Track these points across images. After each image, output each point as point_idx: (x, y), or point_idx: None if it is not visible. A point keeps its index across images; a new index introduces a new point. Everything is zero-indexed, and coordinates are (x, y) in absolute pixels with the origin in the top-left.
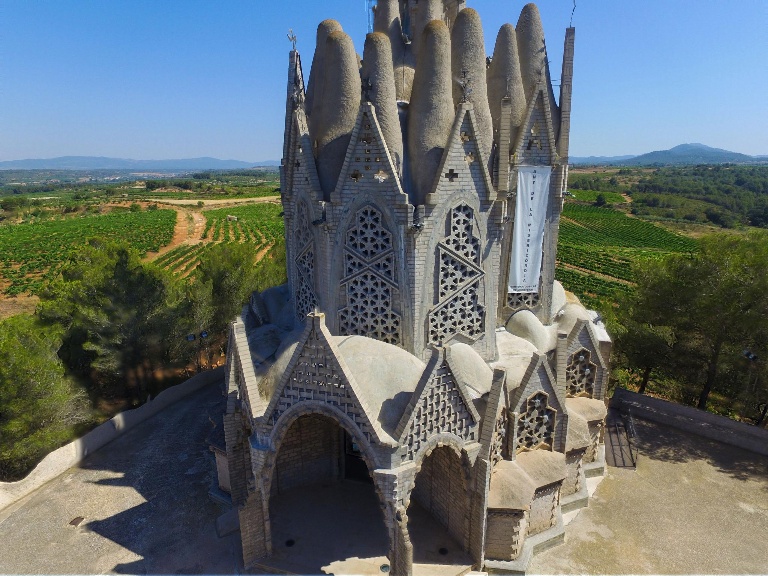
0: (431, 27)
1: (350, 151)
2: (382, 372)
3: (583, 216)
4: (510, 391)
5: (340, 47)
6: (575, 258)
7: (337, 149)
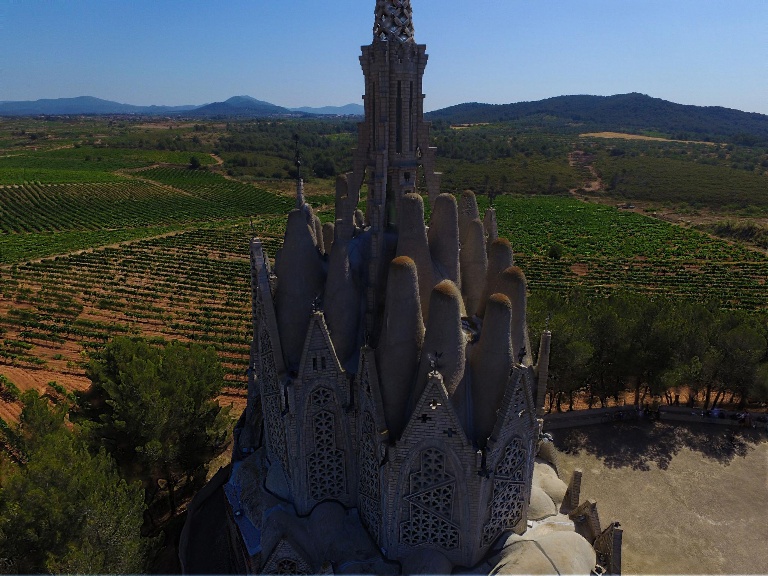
0: (521, 278)
1: (510, 406)
2: (584, 564)
3: (188, 184)
4: (563, 501)
5: (457, 303)
6: (229, 244)
7: (462, 393)
